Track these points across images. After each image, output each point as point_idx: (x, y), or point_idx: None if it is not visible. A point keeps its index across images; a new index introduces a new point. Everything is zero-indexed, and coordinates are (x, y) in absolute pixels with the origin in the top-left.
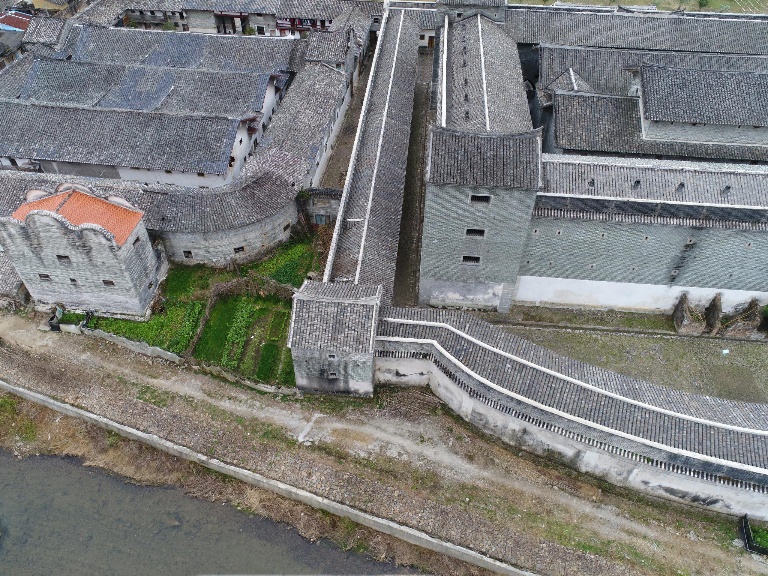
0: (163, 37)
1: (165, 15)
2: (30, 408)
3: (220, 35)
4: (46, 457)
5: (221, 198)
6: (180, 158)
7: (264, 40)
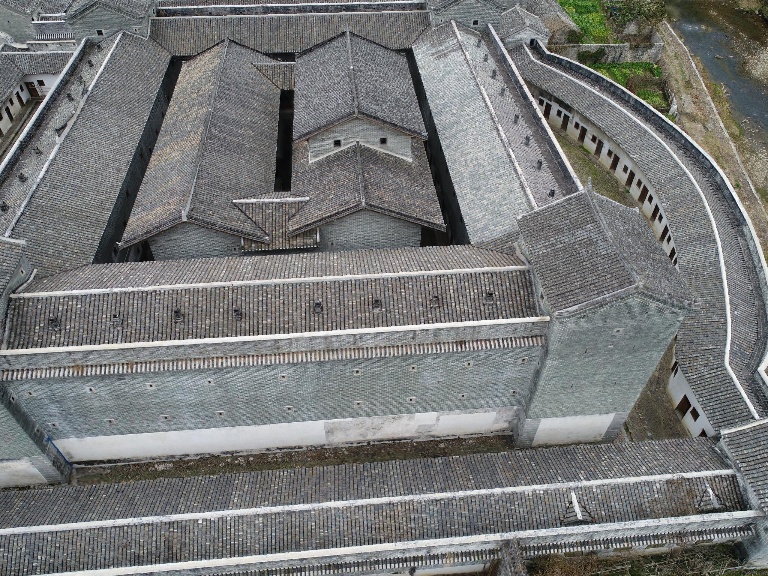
0: None
1: None
2: None
3: None
4: None
5: None
6: None
7: None
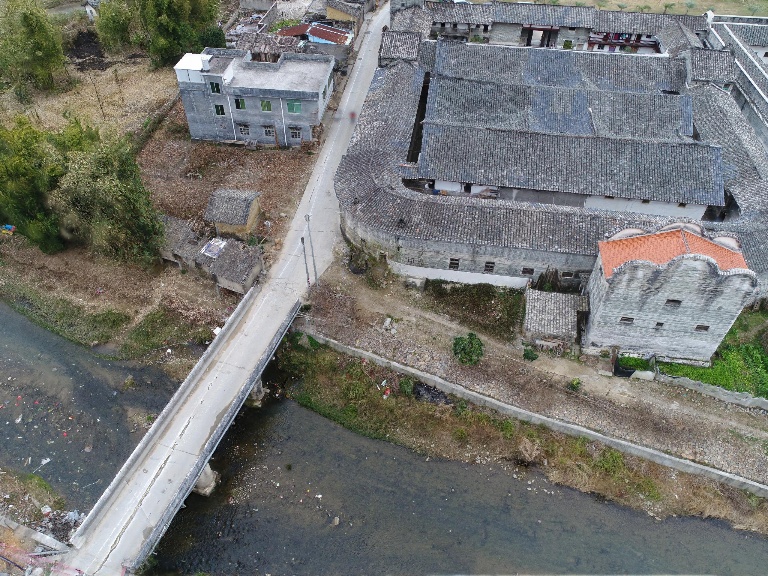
0: (526, 54)
1: (469, 28)
2: (639, 463)
3: (587, 52)
4: (685, 519)
5: (767, 235)
6: (669, 188)
7: (636, 58)
